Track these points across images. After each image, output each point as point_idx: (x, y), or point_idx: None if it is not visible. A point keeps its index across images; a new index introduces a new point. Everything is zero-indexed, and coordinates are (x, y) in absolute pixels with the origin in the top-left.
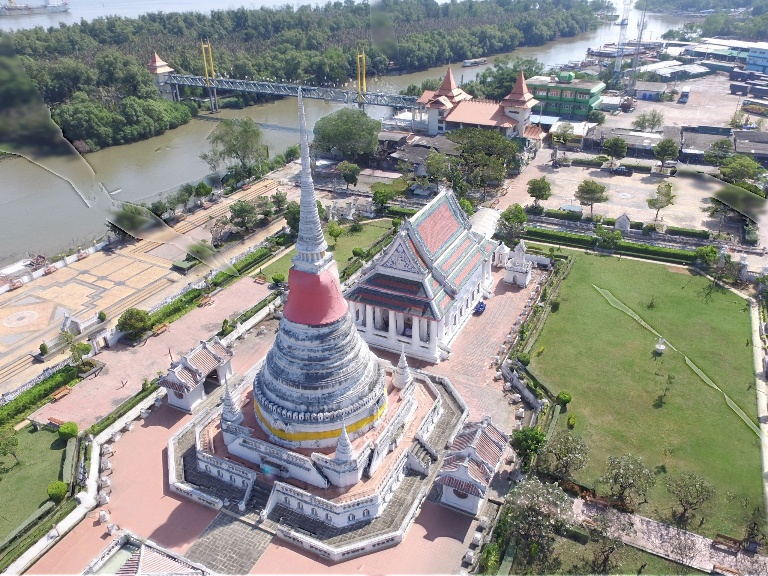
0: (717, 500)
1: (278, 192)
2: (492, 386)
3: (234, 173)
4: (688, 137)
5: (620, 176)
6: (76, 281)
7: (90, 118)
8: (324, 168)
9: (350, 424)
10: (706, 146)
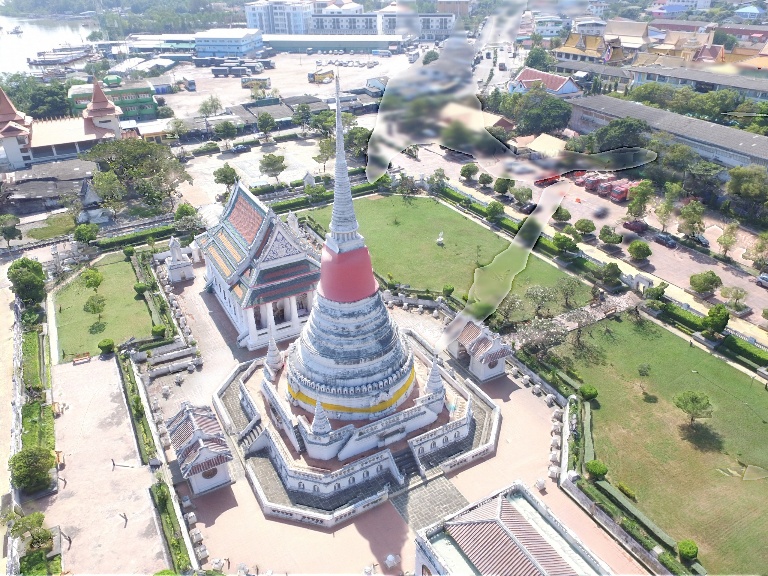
0: None
1: None
2: (396, 313)
3: None
4: (256, 111)
5: (244, 153)
6: None
7: None
8: None
9: None
10: (276, 115)
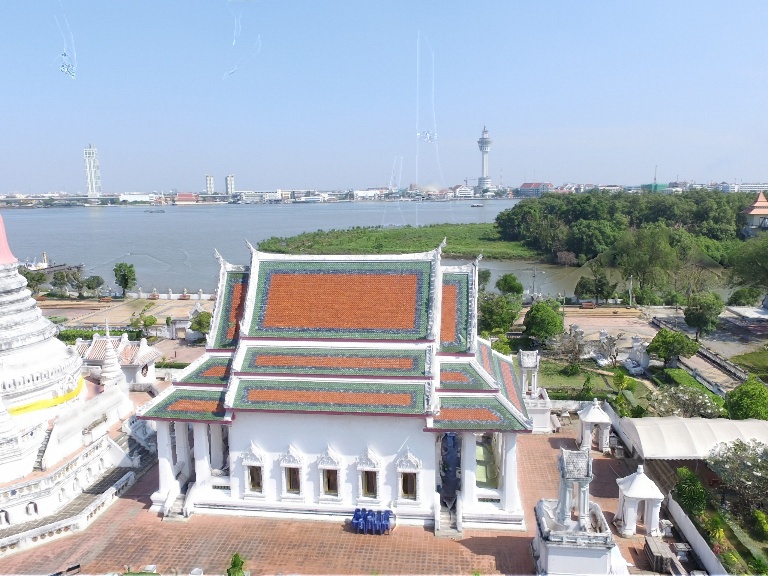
0: None
1: (549, 299)
2: None
3: (578, 283)
4: None
5: None
6: None
7: (594, 234)
8: (745, 320)
9: None
10: None
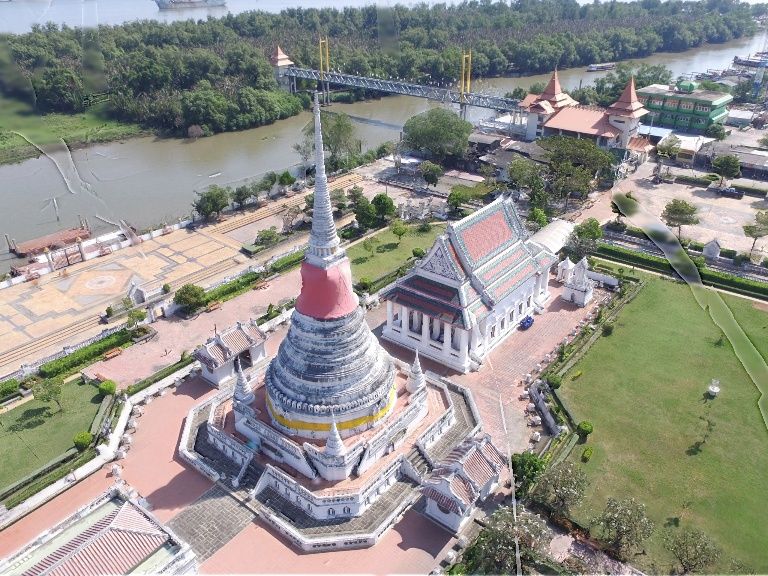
0: (729, 567)
1: (355, 186)
2: (515, 404)
3: None
4: None
5: (728, 198)
6: (156, 254)
7: (208, 105)
8: (411, 166)
9: (347, 420)
10: None
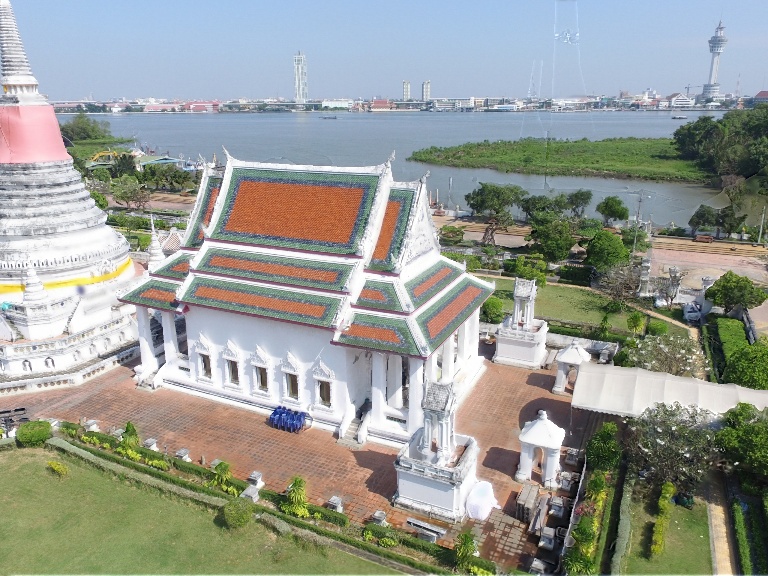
0: None
1: (634, 227)
2: None
3: (696, 211)
4: None
5: None
6: None
7: None
8: None
9: None
10: None
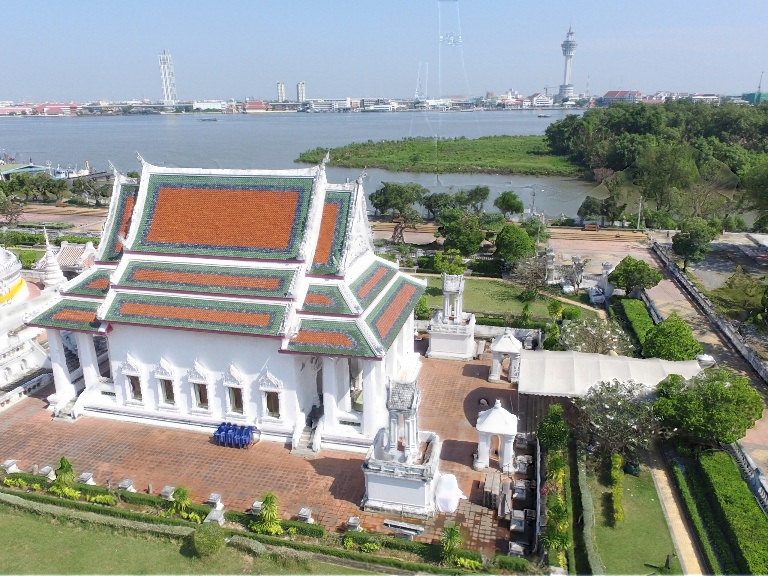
0: None
1: (534, 220)
2: None
3: (583, 203)
4: None
5: None
6: None
7: (636, 149)
8: (758, 249)
9: None
10: None
